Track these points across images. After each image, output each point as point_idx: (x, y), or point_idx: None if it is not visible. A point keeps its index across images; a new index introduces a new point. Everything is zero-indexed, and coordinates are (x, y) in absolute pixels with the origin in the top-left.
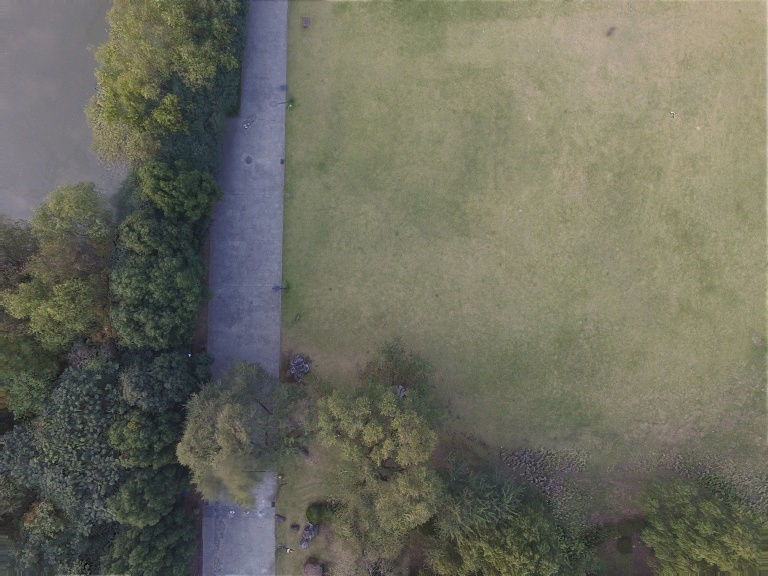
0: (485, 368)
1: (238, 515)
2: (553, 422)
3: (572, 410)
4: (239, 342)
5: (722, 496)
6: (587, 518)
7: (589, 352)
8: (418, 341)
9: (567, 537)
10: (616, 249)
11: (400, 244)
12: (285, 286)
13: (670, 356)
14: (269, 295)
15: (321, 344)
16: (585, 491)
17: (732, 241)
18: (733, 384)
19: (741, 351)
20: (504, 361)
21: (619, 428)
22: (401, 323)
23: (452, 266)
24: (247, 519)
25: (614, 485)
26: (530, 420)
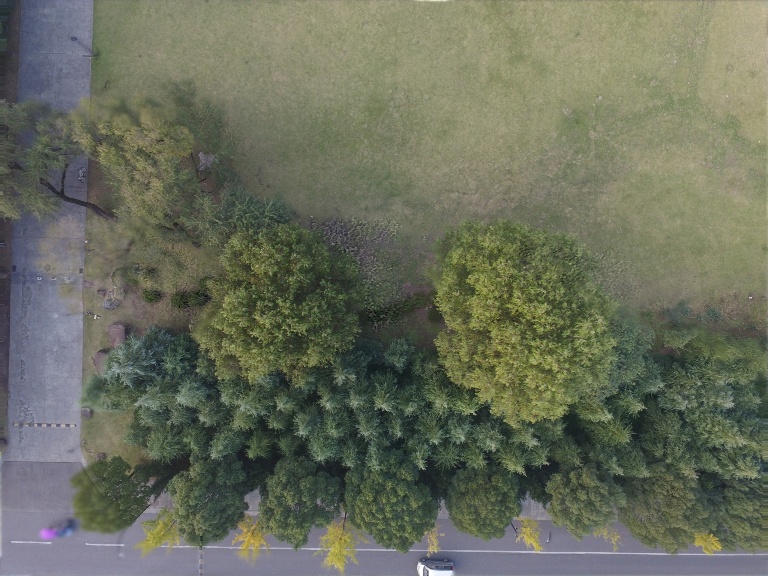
0: (295, 136)
1: (45, 282)
2: (363, 191)
3: (382, 179)
4: (48, 109)
5: (533, 267)
6: (398, 288)
7: (399, 121)
8: (227, 108)
9: (376, 306)
10: (426, 18)
11: (210, 11)
12: (95, 53)
13: (480, 125)
14: (79, 62)
15: (130, 111)
16: (396, 261)
17: (542, 11)
18: (543, 155)
19: (551, 122)
20: (314, 129)
21: (430, 198)
22: (210, 90)
23: (262, 33)
24: (54, 285)
25: (426, 257)
26: (340, 189)
